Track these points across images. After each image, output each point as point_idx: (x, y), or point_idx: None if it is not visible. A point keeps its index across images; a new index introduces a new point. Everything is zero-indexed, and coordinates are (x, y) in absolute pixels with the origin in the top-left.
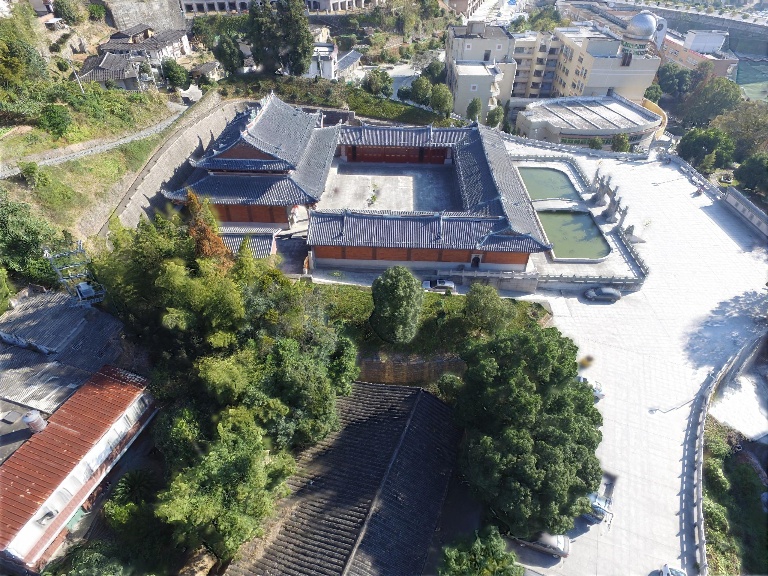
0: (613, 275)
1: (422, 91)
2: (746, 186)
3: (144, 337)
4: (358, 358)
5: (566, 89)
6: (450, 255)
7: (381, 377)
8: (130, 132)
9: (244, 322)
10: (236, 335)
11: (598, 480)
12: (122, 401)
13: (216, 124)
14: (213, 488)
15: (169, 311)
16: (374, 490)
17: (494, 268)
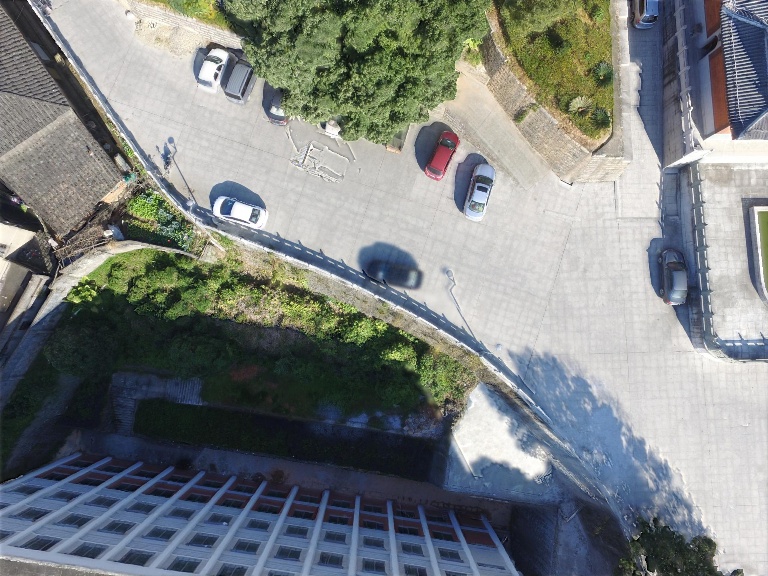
0: None
1: None
2: None
3: None
4: None
5: None
6: None
7: None
8: None
9: None
10: None
11: (268, 59)
12: None
13: None
14: None
15: None
16: None
17: (703, 85)
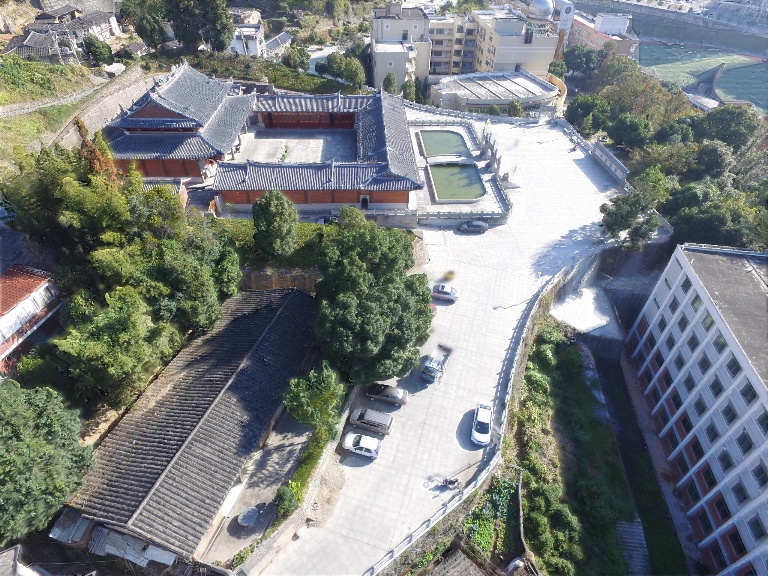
0: (482, 210)
1: (336, 65)
2: (615, 142)
3: (47, 238)
4: (247, 271)
5: (482, 67)
6: (342, 197)
7: (269, 288)
8: (51, 100)
9: (132, 225)
10: (126, 236)
11: (411, 330)
12: (29, 287)
13: (139, 95)
14: (100, 337)
15: (65, 214)
16: (245, 354)
17: (381, 208)
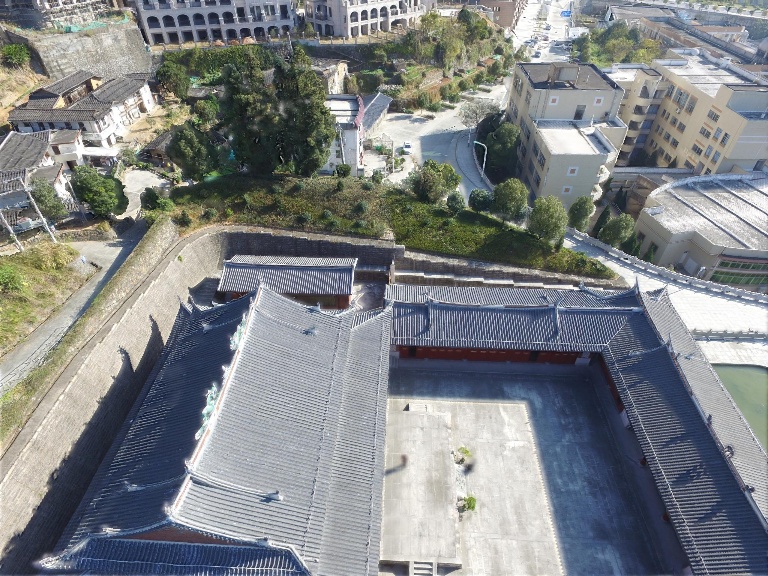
0: None
1: (513, 203)
2: None
3: None
4: None
5: (680, 151)
6: None
7: None
8: None
9: None
10: None
11: None
12: None
13: (164, 295)
14: None
15: None
16: None
17: None
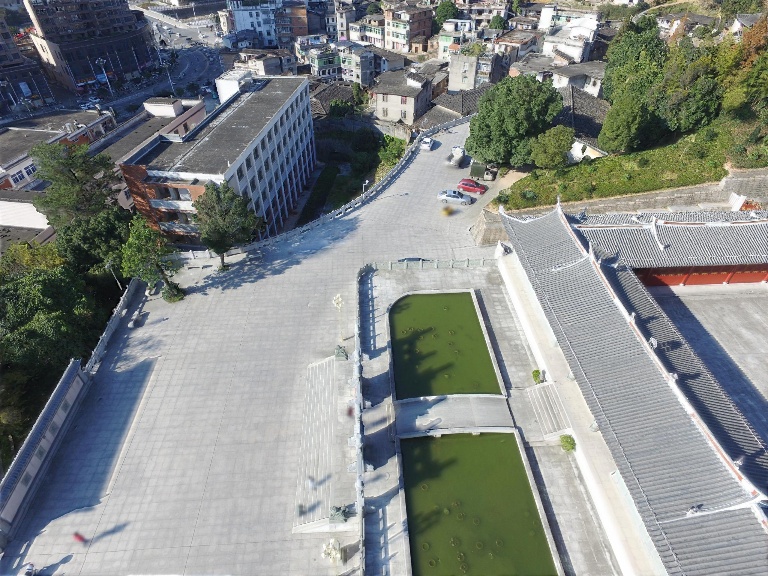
0: None
1: None
2: None
3: None
4: None
5: None
6: None
7: None
8: None
9: None
10: None
11: None
12: None
13: None
14: None
15: None
16: None
17: None
